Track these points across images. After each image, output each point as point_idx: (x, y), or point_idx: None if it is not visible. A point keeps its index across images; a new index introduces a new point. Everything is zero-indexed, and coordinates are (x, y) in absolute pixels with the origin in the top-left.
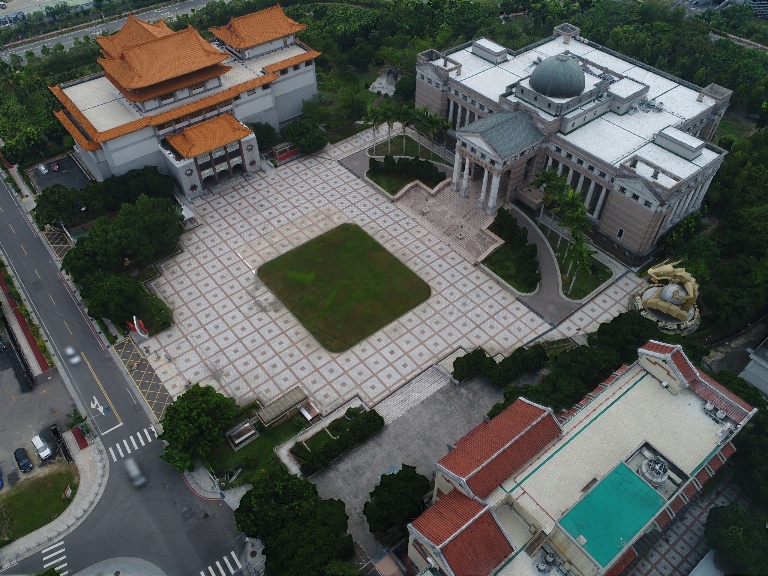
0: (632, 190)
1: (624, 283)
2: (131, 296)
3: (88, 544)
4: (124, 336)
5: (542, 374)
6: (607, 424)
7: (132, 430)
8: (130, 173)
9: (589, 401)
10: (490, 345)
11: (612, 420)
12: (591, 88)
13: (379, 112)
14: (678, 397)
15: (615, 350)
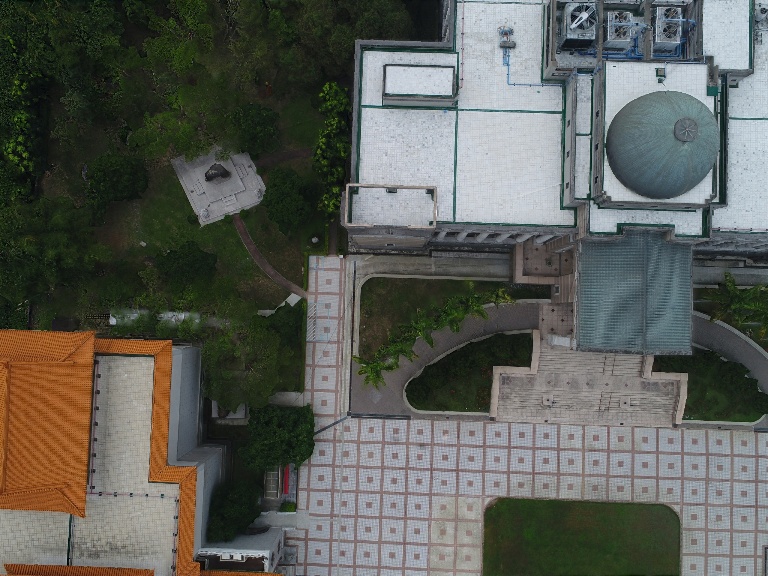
0: None
1: None
2: None
3: None
4: None
5: None
6: None
7: None
8: None
9: None
10: None
11: None
12: (710, 107)
13: None
14: None
15: None
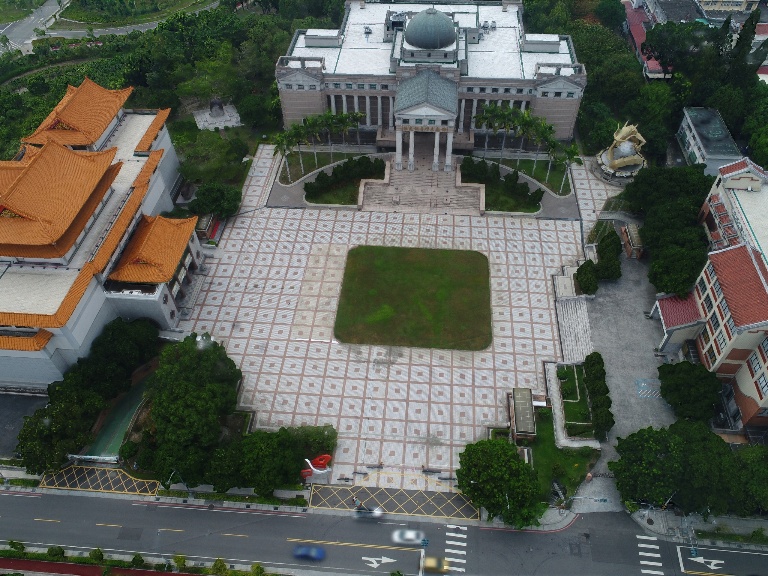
0: (555, 90)
1: (575, 165)
2: None
3: None
4: (305, 489)
5: (632, 250)
6: (762, 232)
7: (439, 545)
8: (101, 342)
9: (736, 227)
10: (566, 260)
11: (760, 228)
12: (455, 29)
13: (291, 135)
14: (762, 191)
15: (668, 198)
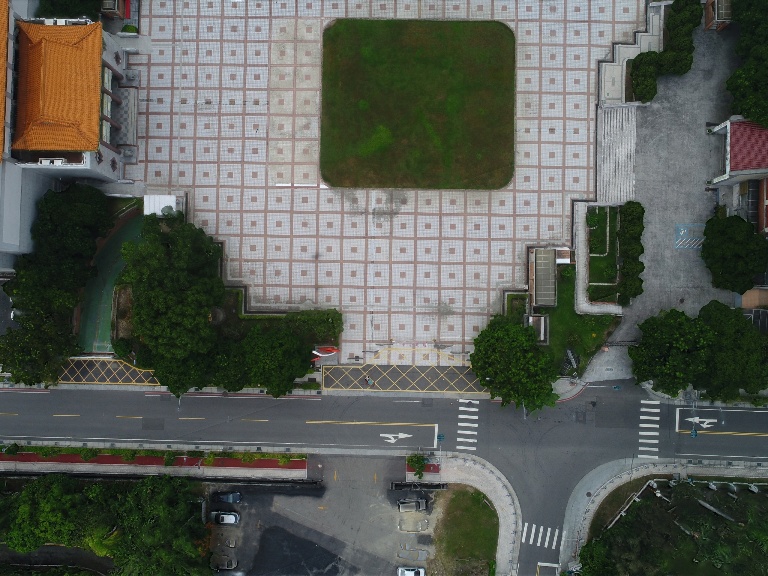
0: None
1: None
2: (298, 345)
3: (545, 505)
4: (316, 371)
5: (714, 22)
6: None
7: (452, 420)
8: (42, 233)
9: None
10: (620, 32)
11: None
12: None
13: None
14: None
15: None
